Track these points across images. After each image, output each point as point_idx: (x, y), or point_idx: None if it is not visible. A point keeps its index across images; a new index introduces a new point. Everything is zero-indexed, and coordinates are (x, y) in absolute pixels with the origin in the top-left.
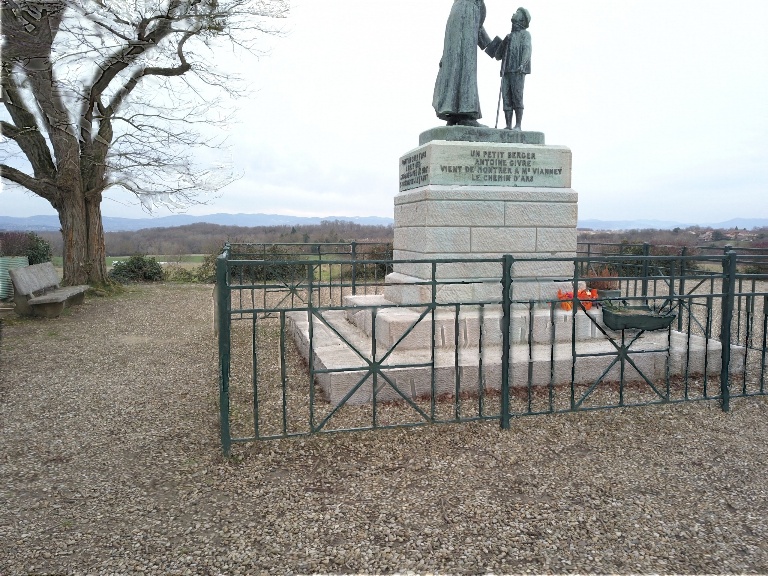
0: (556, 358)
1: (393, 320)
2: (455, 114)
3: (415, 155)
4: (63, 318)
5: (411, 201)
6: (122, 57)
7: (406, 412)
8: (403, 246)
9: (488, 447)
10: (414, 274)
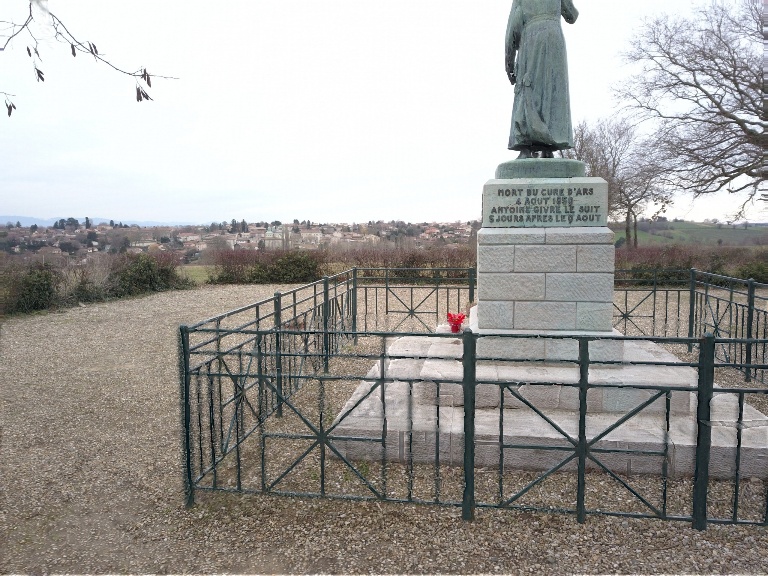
0: None
1: (678, 381)
2: (553, 145)
3: (556, 189)
4: None
5: (554, 243)
6: None
7: None
8: (531, 296)
9: None
10: (574, 327)
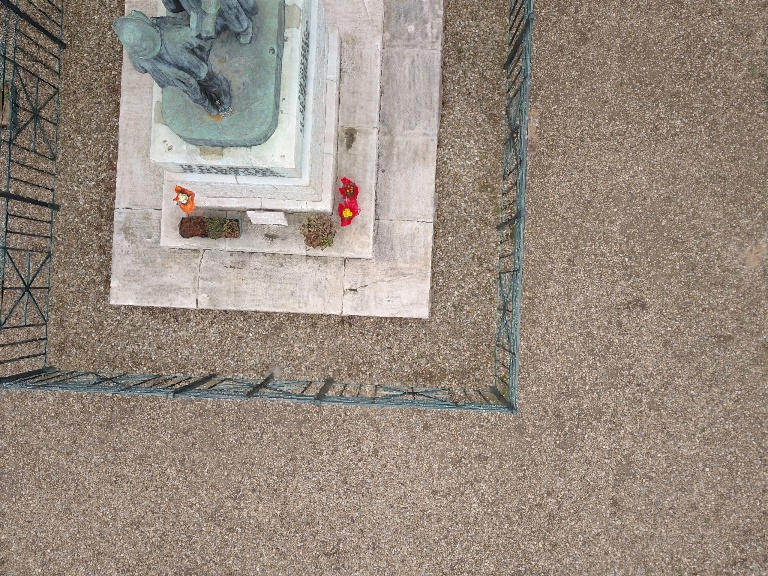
0: (122, 120)
1: None
2: None
3: None
4: None
5: None
6: None
7: (113, 1)
8: None
9: (49, 28)
10: None
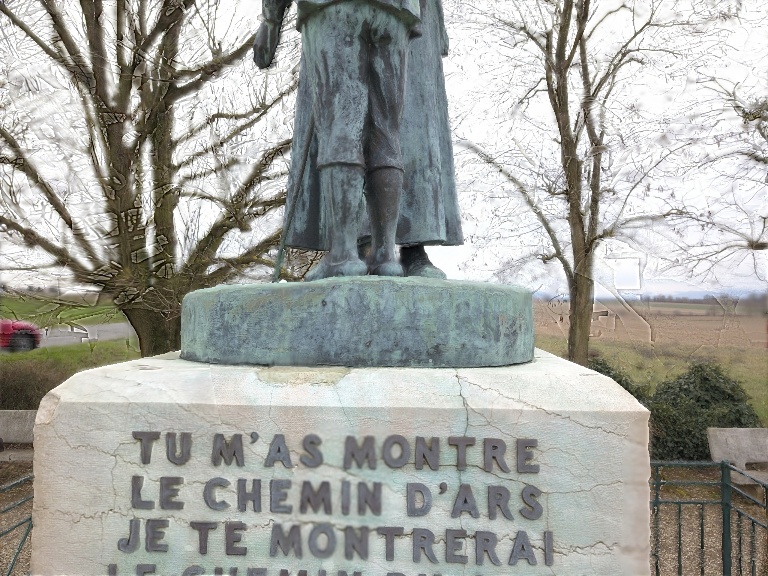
0: None
1: None
2: None
3: None
4: (760, 509)
5: None
6: (677, 170)
7: None
8: None
9: None
10: None
